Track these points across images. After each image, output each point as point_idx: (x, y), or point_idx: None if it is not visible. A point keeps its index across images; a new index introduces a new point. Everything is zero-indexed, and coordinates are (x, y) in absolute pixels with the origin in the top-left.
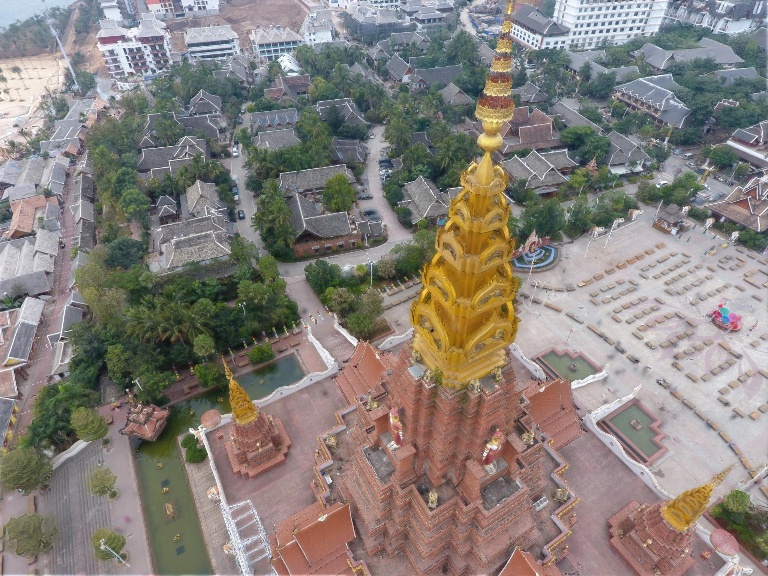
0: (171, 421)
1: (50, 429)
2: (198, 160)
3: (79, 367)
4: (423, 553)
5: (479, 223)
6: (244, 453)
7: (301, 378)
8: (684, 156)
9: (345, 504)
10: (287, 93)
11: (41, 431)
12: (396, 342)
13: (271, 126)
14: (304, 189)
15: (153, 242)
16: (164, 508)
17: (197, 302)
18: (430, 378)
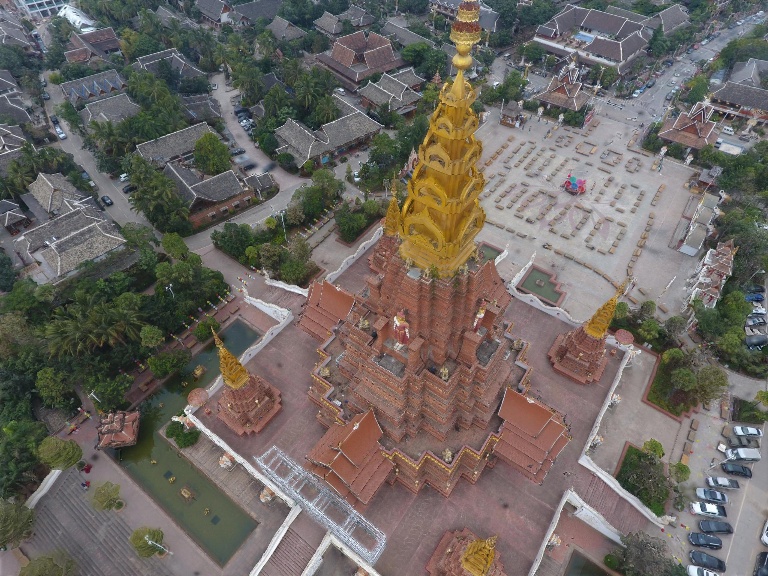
0: (142, 421)
1: (14, 474)
2: (30, 150)
3: (5, 407)
4: (443, 419)
5: (462, 131)
6: (244, 415)
7: (256, 338)
8: (504, 57)
9: (369, 409)
10: (95, 53)
11: (3, 480)
12: (334, 278)
13: (93, 95)
14: (170, 157)
15: (18, 255)
16: (180, 494)
17: (119, 298)
18: (428, 275)
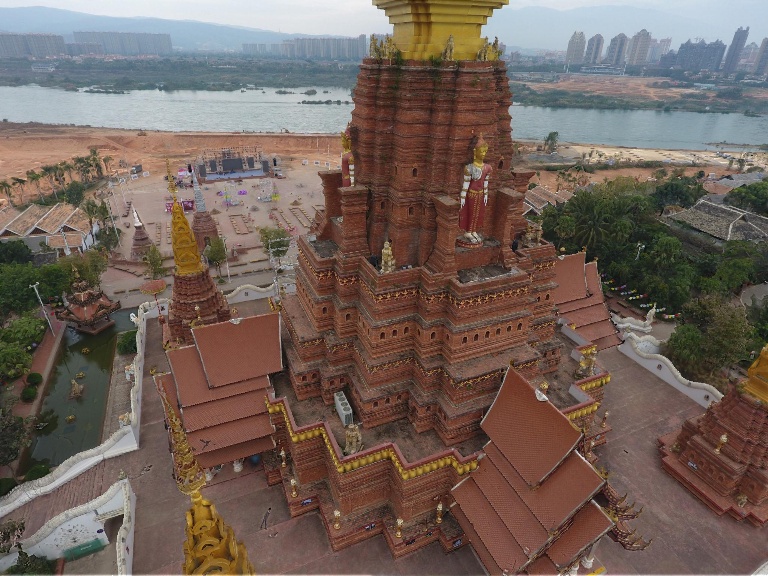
0: None
1: None
2: None
3: None
4: None
5: None
6: None
7: None
8: None
9: None
10: None
11: None
12: (669, 378)
13: None
14: None
15: None
16: None
17: None
18: None
